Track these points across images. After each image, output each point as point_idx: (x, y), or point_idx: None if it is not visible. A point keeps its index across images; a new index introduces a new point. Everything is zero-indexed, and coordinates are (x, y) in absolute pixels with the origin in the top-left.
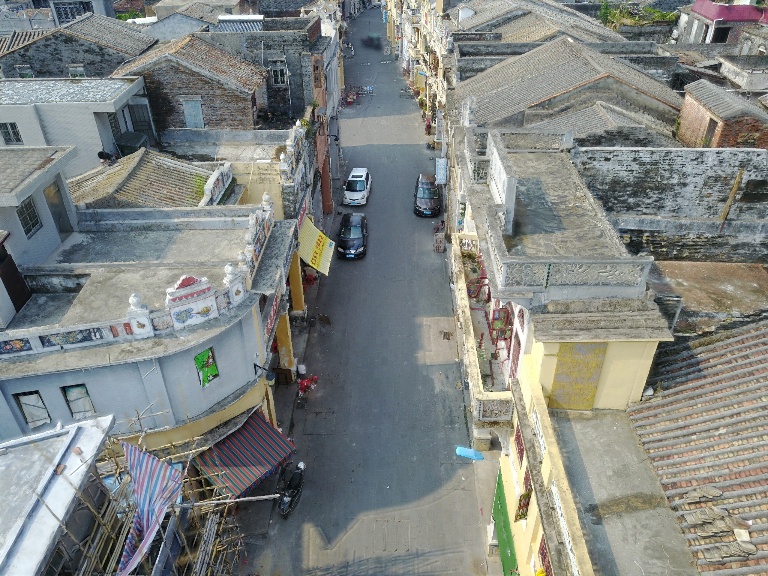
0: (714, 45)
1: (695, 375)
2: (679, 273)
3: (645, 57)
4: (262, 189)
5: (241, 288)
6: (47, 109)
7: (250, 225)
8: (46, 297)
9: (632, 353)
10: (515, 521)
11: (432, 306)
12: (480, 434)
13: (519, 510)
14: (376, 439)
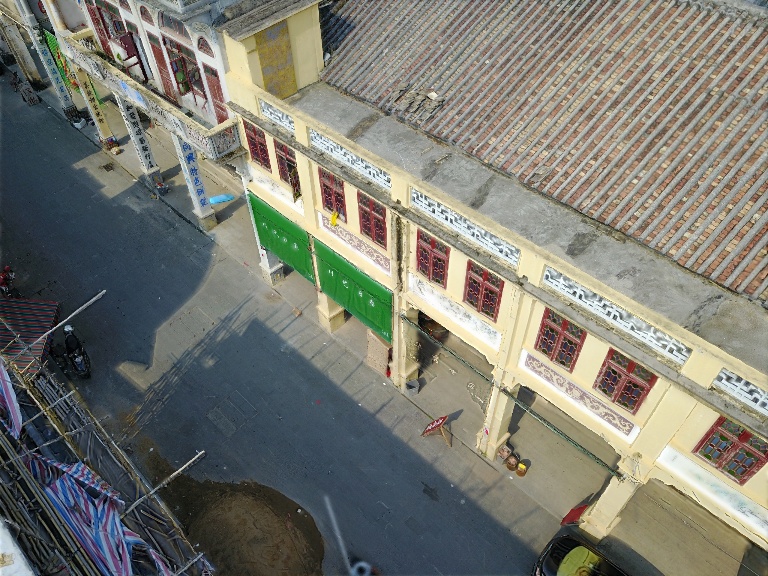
0: None
1: (348, 29)
2: None
3: None
4: None
5: None
6: None
7: None
8: None
9: (305, 24)
10: (295, 201)
11: (72, 152)
12: (204, 213)
13: (294, 189)
14: (116, 275)
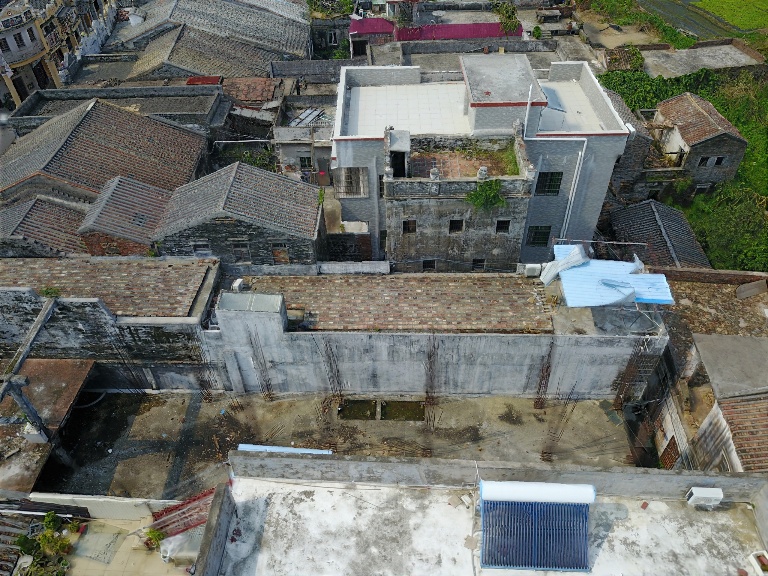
0: (344, 61)
1: None
2: (19, 372)
3: (177, 114)
4: None
5: None
6: None
7: None
8: None
9: None
10: None
11: None
12: None
13: None
14: None
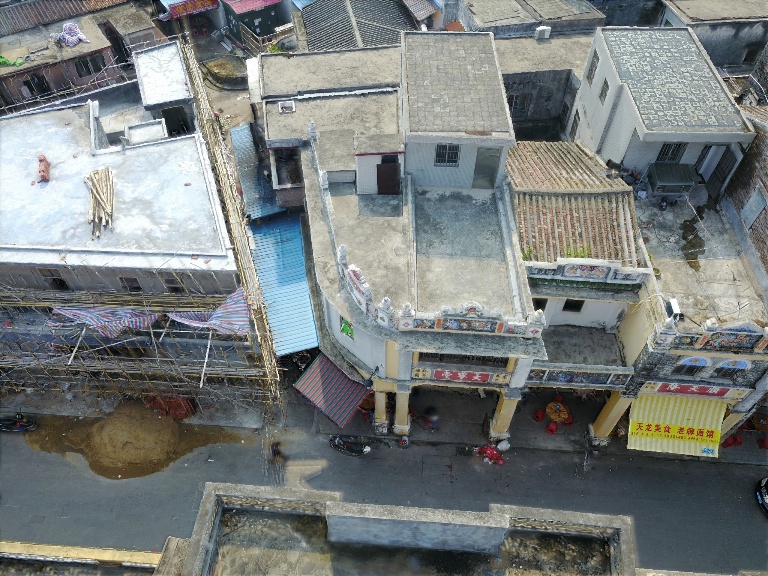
0: None
1: None
2: None
3: None
4: (644, 321)
5: (387, 320)
6: (625, 95)
7: (461, 305)
8: (398, 203)
9: None
10: None
11: None
12: None
13: None
14: None
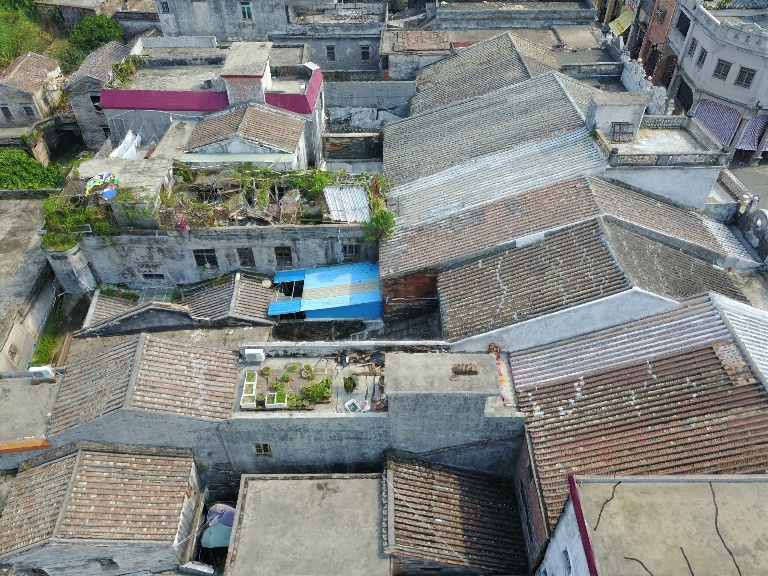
0: (332, 83)
1: None
2: None
3: None
4: None
5: None
6: None
7: None
8: None
9: None
10: None
11: None
12: None
13: None
14: None
